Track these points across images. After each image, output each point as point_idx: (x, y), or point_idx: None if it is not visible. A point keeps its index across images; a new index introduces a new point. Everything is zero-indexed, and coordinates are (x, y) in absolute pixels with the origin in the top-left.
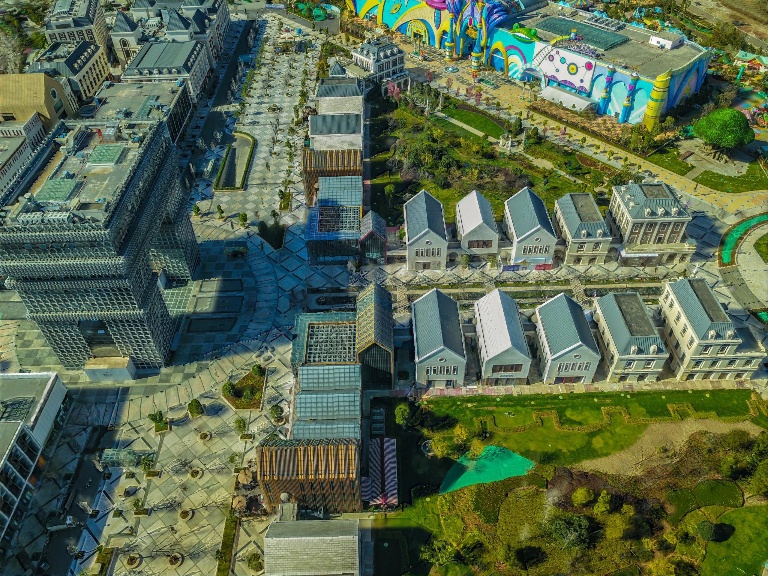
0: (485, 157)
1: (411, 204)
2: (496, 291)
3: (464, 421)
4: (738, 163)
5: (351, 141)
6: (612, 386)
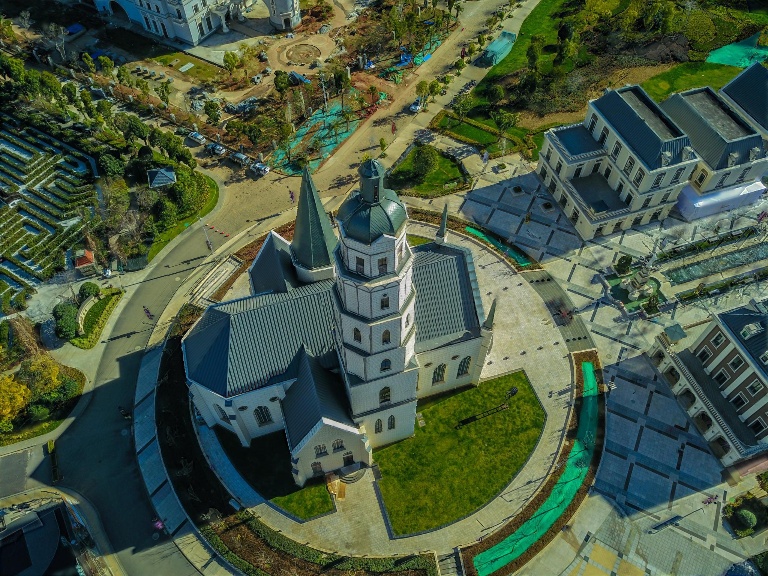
0: None
1: None
2: None
3: None
4: None
5: None
6: None
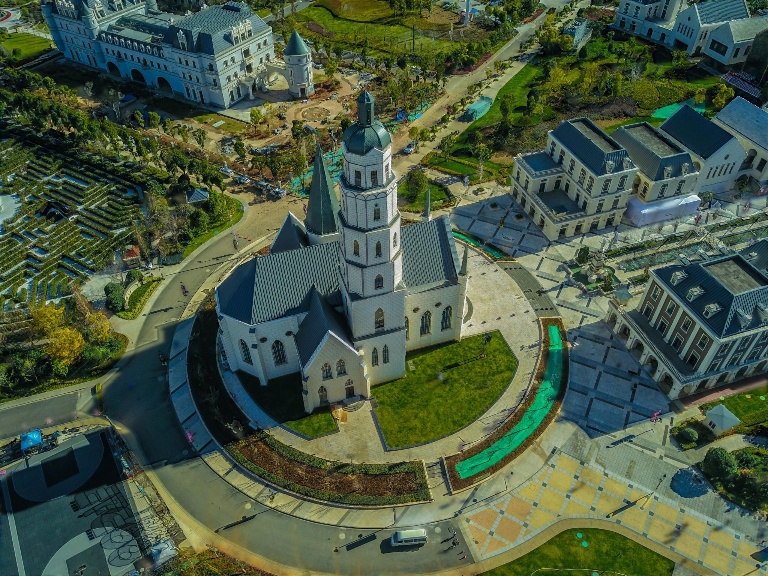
0: None
1: None
2: None
3: None
4: None
5: None
6: None
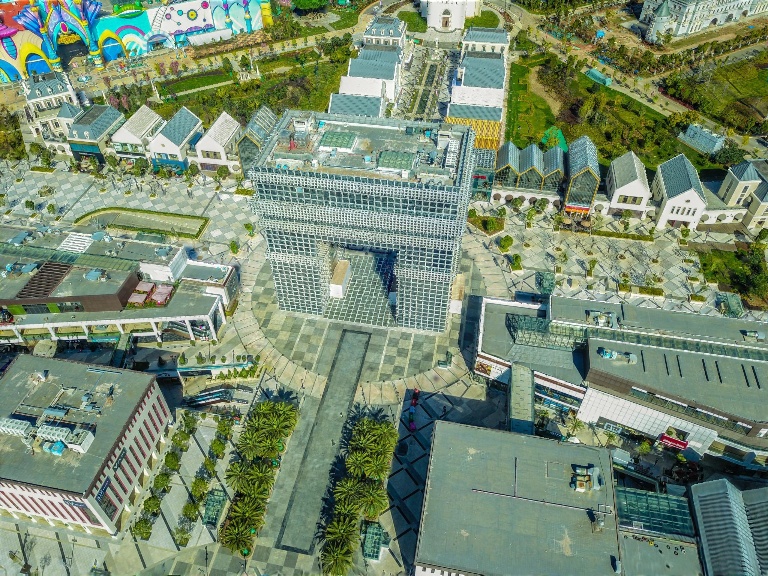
0: (256, 88)
1: (335, 108)
2: (455, 87)
3: (523, 143)
4: (327, 14)
5: (224, 119)
6: (505, 94)
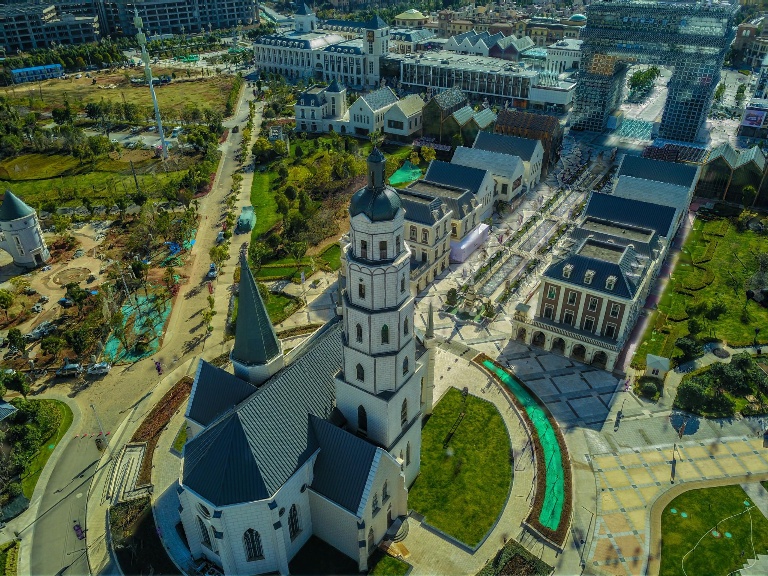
0: None
1: None
2: None
3: None
4: None
5: None
6: None
